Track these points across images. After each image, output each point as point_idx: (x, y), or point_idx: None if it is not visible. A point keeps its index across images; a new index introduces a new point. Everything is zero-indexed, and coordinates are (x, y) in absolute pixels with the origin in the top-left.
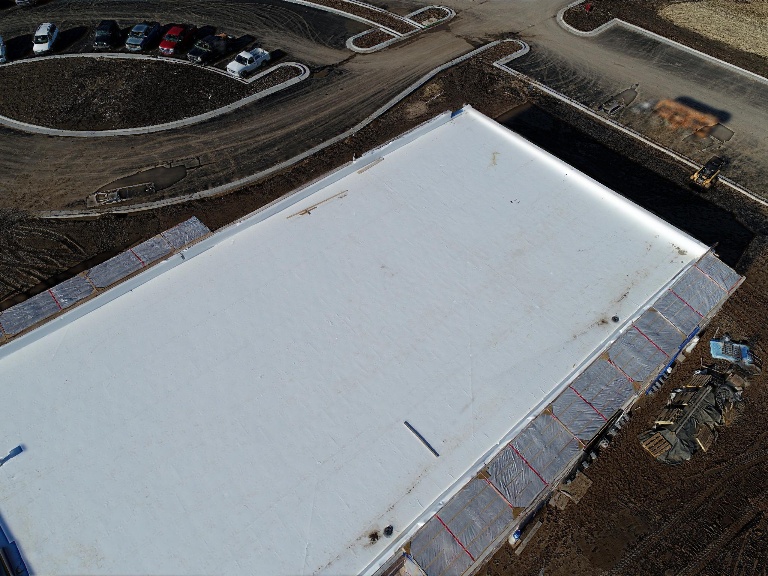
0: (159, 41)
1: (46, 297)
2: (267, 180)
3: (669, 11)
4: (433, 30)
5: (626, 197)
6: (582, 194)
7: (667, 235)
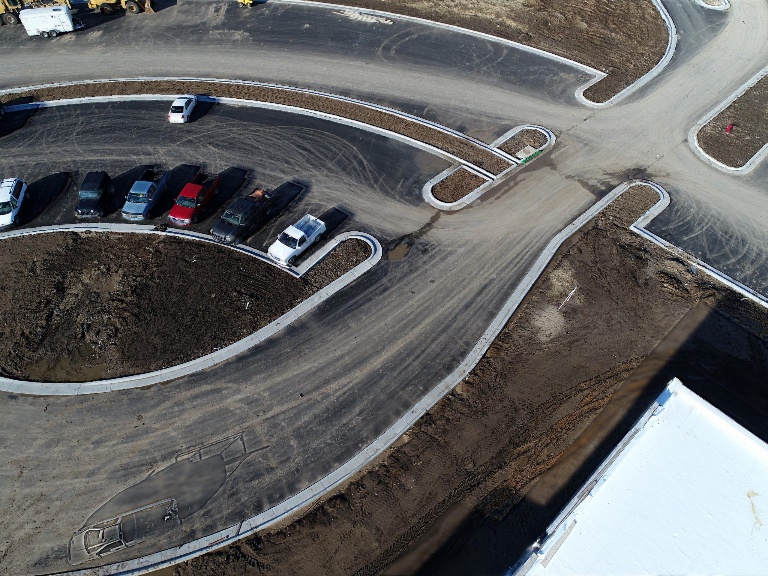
0: (167, 198)
1: None
2: (353, 486)
3: None
4: (533, 166)
5: None
6: None
7: None
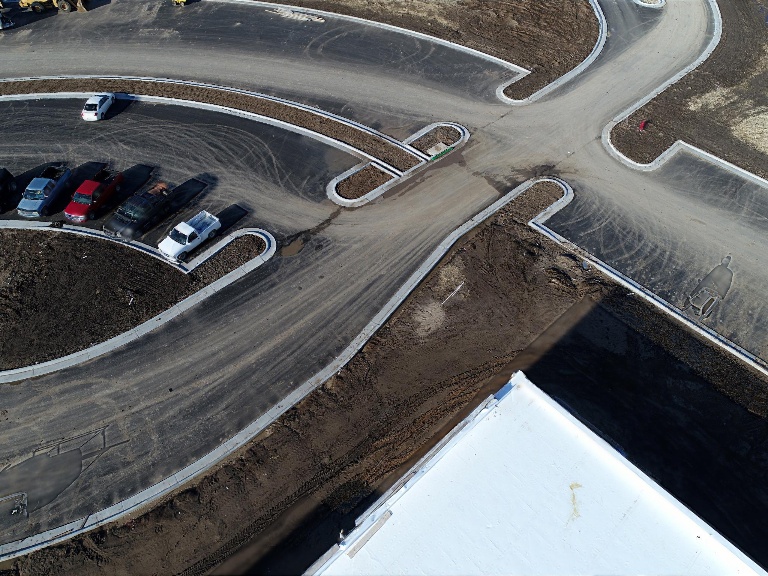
0: (69, 195)
1: None
2: (207, 480)
3: (746, 129)
4: (442, 163)
5: None
6: None
7: None
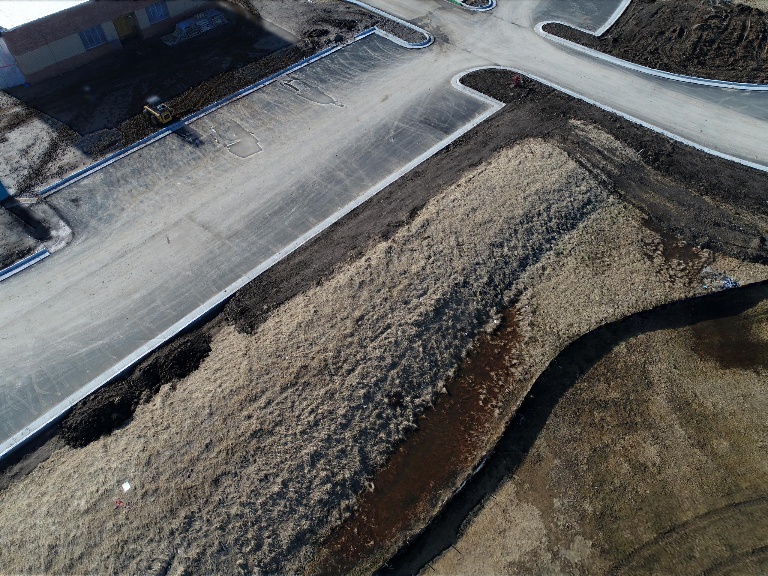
0: None
1: None
2: None
3: (539, 145)
4: (440, 1)
5: (73, 6)
6: None
7: None
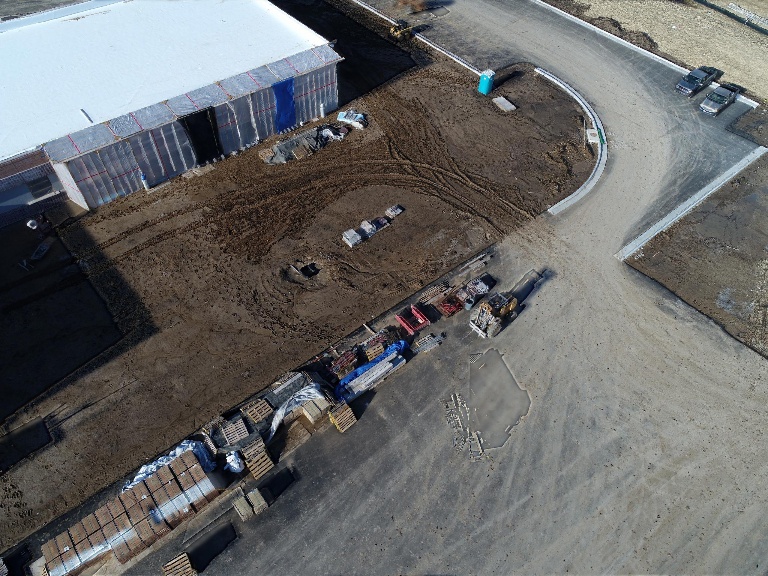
0: None
1: None
2: None
3: None
4: None
5: None
6: (272, 19)
7: (313, 40)
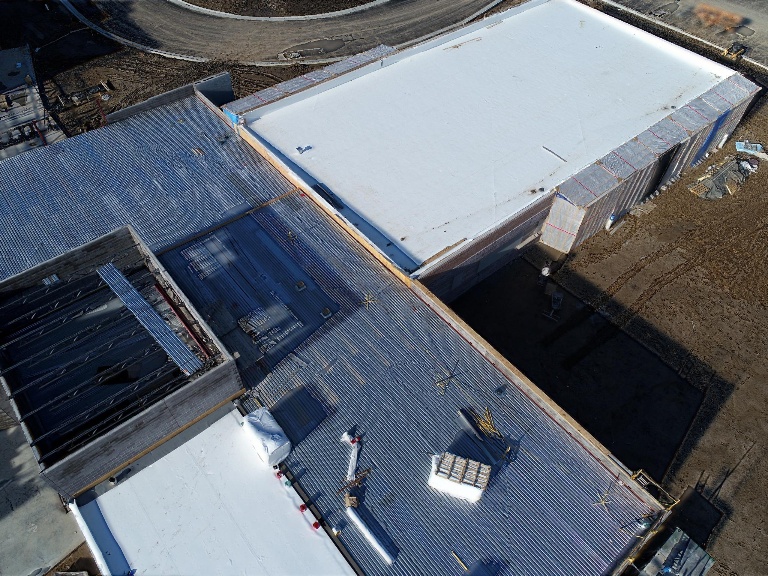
0: None
1: (301, 78)
2: None
3: None
4: None
5: None
6: (646, 45)
7: (707, 67)
